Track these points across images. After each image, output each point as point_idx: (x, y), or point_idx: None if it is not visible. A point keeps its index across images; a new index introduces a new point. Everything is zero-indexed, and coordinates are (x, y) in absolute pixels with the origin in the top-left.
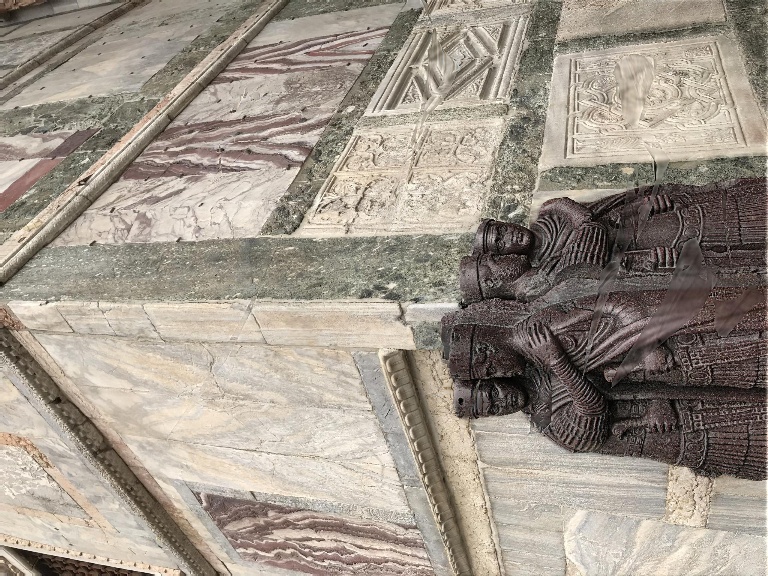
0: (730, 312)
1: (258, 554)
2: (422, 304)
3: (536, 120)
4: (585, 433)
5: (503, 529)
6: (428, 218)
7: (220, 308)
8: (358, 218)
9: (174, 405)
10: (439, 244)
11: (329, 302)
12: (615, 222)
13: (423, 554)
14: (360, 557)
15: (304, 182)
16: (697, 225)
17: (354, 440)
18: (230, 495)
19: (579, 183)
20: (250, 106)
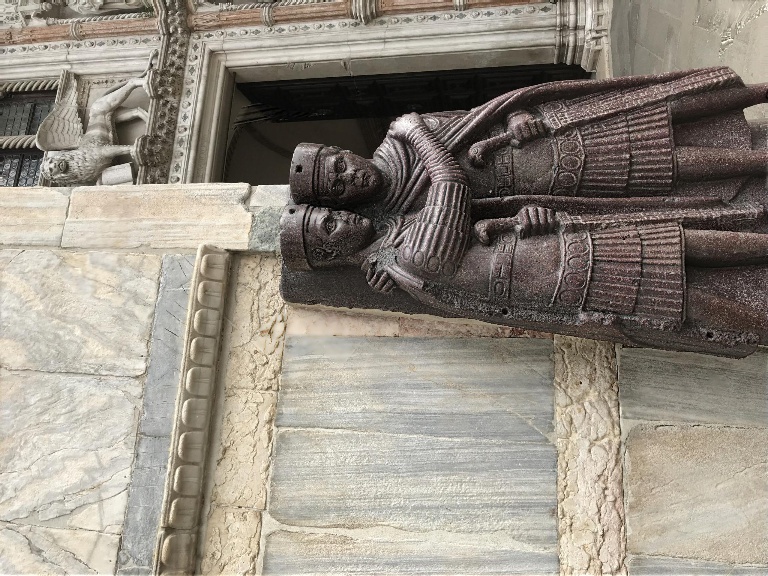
0: None
1: None
2: None
3: None
4: (442, 212)
5: None
6: None
7: (35, 189)
8: None
9: None
10: None
11: None
12: None
13: None
14: None
15: None
16: None
17: (82, 458)
18: None
19: None
20: None
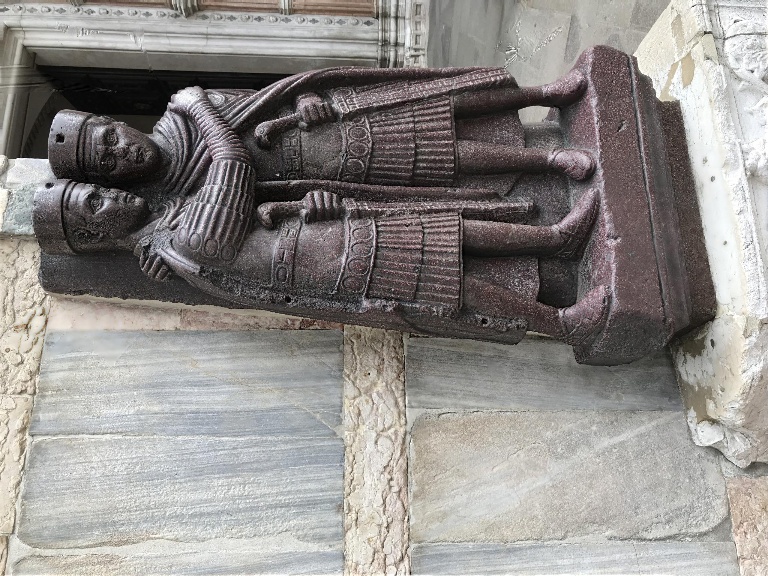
0: None
1: None
2: None
3: None
4: (221, 191)
5: None
6: None
7: None
8: None
9: None
10: None
11: None
12: None
13: None
14: None
15: None
16: None
17: None
18: None
19: None
20: None
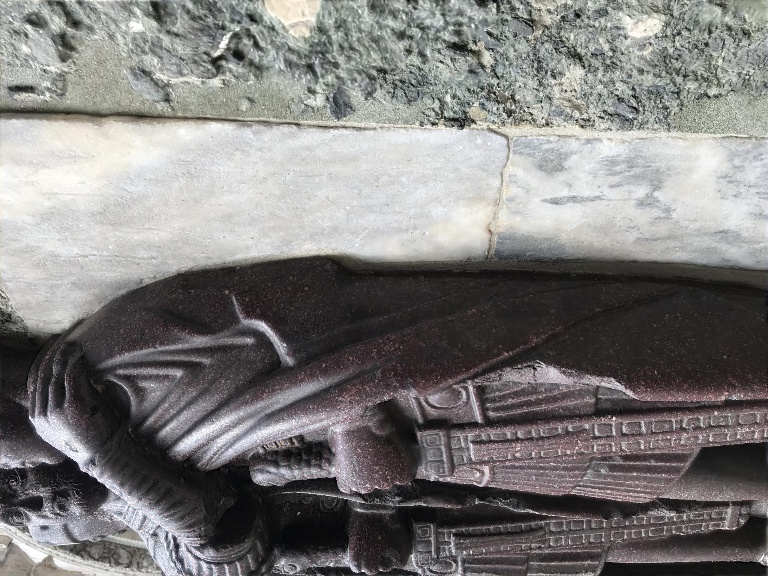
0: None
1: None
2: None
3: None
4: None
5: None
6: None
7: None
8: None
9: None
10: None
11: None
12: None
13: None
14: None
15: None
16: None
17: None
18: None
19: (74, 54)
20: None
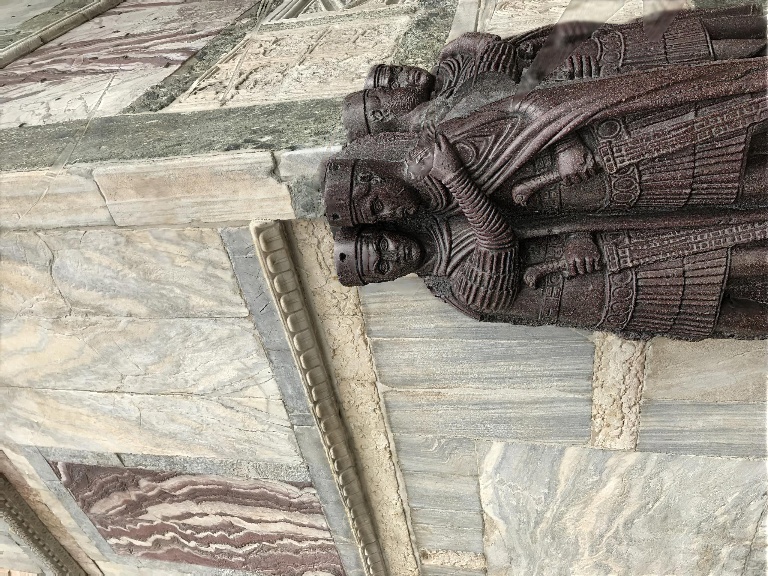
0: (662, 7)
1: (133, 545)
2: (299, 150)
3: (445, 14)
4: (491, 279)
5: (411, 479)
6: (317, 88)
7: None
8: (238, 95)
9: (13, 332)
10: (327, 105)
11: (187, 157)
12: (525, 51)
13: (322, 523)
14: (250, 535)
15: (182, 75)
16: (617, 48)
17: (231, 364)
18: (93, 462)
19: None
20: (136, 27)
